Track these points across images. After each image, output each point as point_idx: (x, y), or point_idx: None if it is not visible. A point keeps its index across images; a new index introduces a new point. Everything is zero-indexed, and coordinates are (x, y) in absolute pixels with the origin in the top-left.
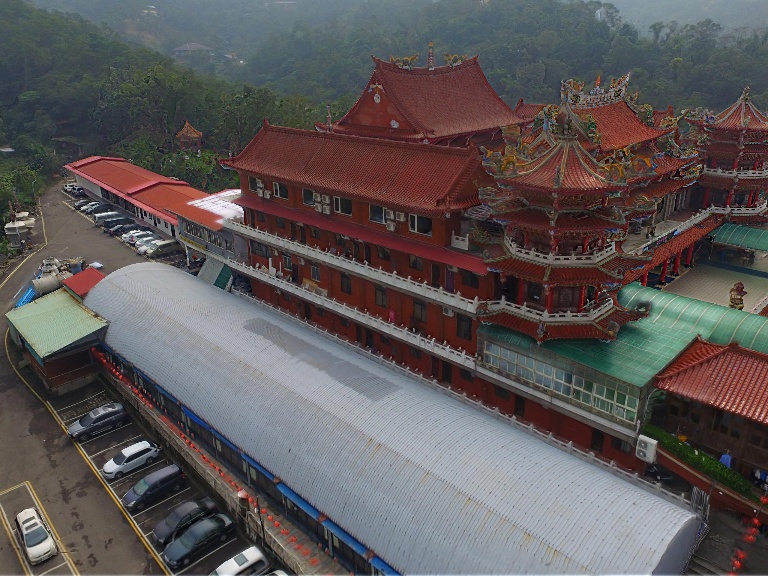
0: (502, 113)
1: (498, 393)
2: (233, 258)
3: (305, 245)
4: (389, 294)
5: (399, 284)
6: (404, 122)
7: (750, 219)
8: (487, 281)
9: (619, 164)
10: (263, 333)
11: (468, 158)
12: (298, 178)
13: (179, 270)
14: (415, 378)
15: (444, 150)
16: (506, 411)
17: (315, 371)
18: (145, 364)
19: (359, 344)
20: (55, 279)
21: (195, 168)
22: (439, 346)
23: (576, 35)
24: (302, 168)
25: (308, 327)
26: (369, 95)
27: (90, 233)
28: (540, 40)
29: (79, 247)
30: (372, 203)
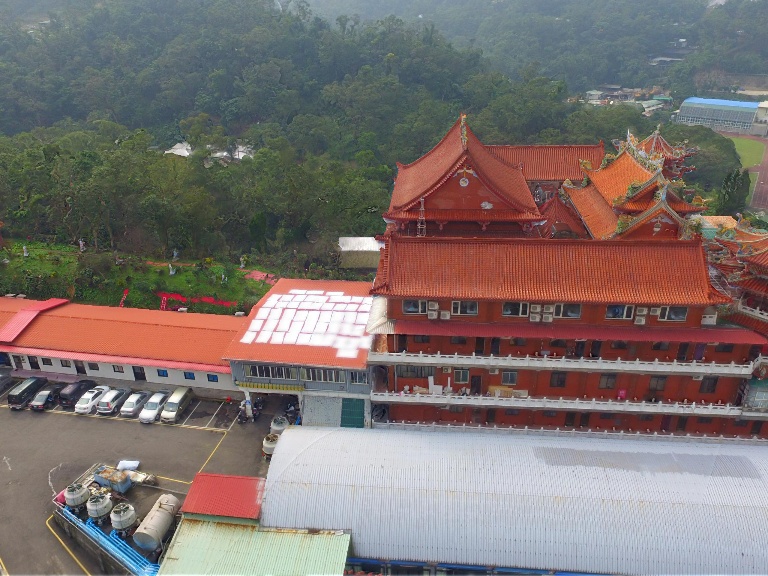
0: (505, 167)
1: (736, 424)
2: (374, 390)
3: (524, 357)
4: (622, 377)
5: (662, 369)
6: (501, 203)
7: None
8: (745, 345)
9: None
10: (575, 462)
11: (695, 248)
12: (514, 295)
13: (322, 429)
14: (665, 439)
15: (666, 244)
16: (745, 435)
17: (681, 476)
18: (465, 554)
19: (576, 428)
20: (165, 514)
21: (47, 274)
22: (701, 407)
23: (281, 30)
24: (501, 282)
25: (514, 432)
26: (453, 180)
27: None
28: (252, 37)
29: (26, 449)
30: (617, 304)
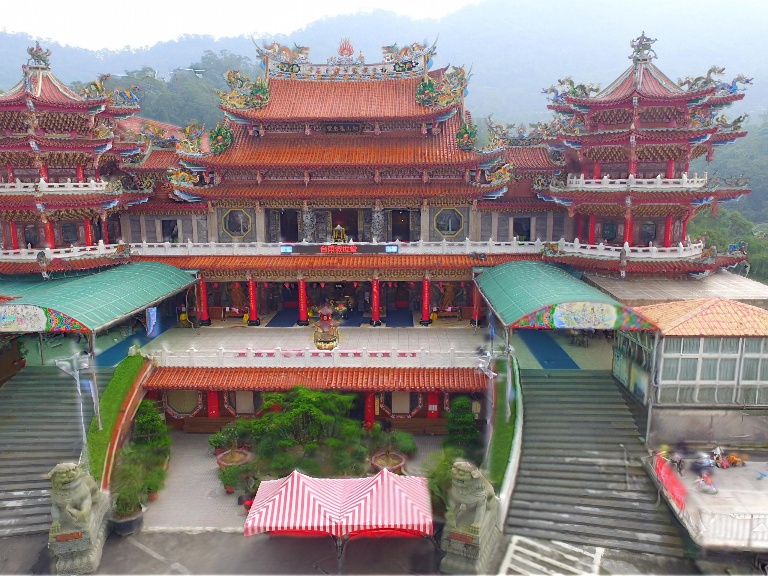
0: None
1: None
2: None
3: None
4: None
5: None
6: None
7: (594, 263)
8: None
9: (93, 99)
10: None
11: None
12: None
13: None
14: None
15: None
16: None
17: None
18: None
19: None
20: None
21: None
22: None
23: None
24: None
25: None
26: None
27: None
28: None
29: None
30: None
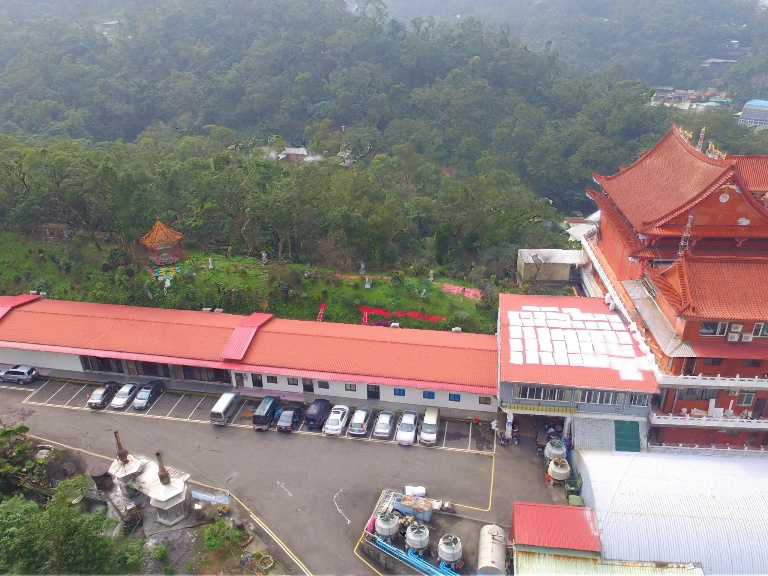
0: None
1: None
2: (655, 413)
3: None
4: None
5: None
6: (760, 219)
7: None
8: None
9: None
10: None
11: None
12: None
13: (618, 454)
14: None
15: None
16: None
17: None
18: None
19: None
20: (501, 546)
21: (241, 288)
22: None
23: (362, 32)
24: None
25: None
26: (714, 195)
27: (242, 442)
28: (336, 39)
29: (296, 473)
30: None
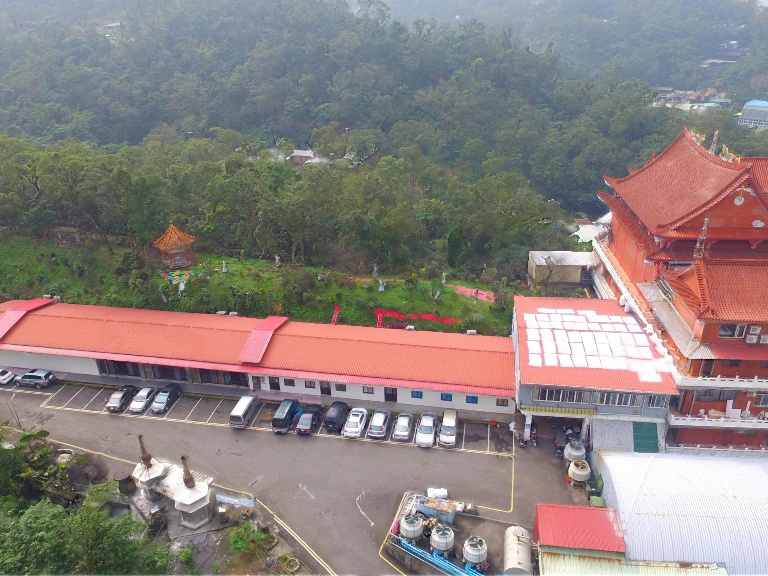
0: None
1: None
2: None
3: None
4: None
5: None
6: None
7: None
8: None
9: None
10: None
11: None
12: None
13: (638, 455)
14: None
15: None
16: None
17: None
18: None
19: None
20: (527, 547)
21: (255, 291)
22: None
23: (365, 34)
24: None
25: None
26: (729, 198)
27: (262, 445)
28: (339, 41)
29: (317, 476)
30: None
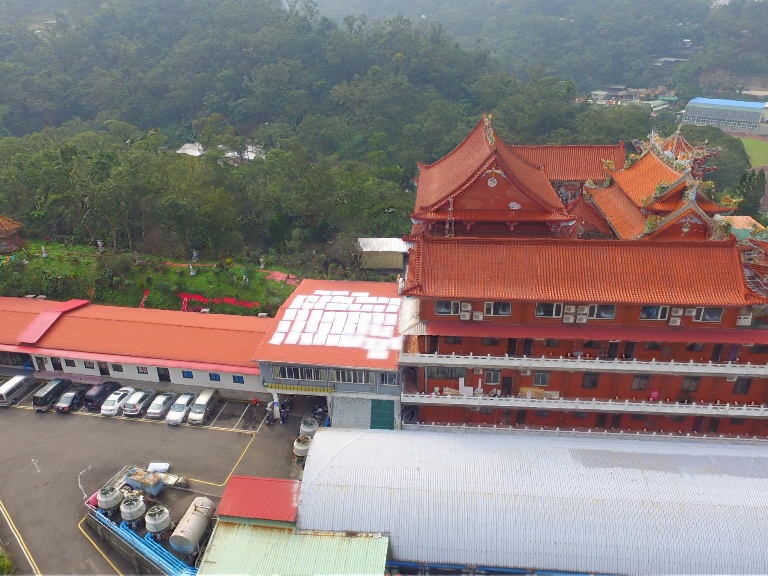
0: None
1: None
2: (404, 392)
3: (557, 358)
4: (655, 378)
5: (697, 370)
6: (529, 203)
7: None
8: None
9: None
10: (613, 464)
11: (730, 249)
12: (549, 296)
13: (354, 430)
14: (698, 440)
15: (700, 244)
16: None
17: (720, 478)
18: (505, 557)
19: None
20: (201, 516)
21: (67, 275)
22: (735, 408)
23: (289, 30)
24: (535, 283)
25: (545, 433)
26: (482, 180)
27: (17, 423)
28: (260, 37)
29: (54, 451)
30: (652, 305)
